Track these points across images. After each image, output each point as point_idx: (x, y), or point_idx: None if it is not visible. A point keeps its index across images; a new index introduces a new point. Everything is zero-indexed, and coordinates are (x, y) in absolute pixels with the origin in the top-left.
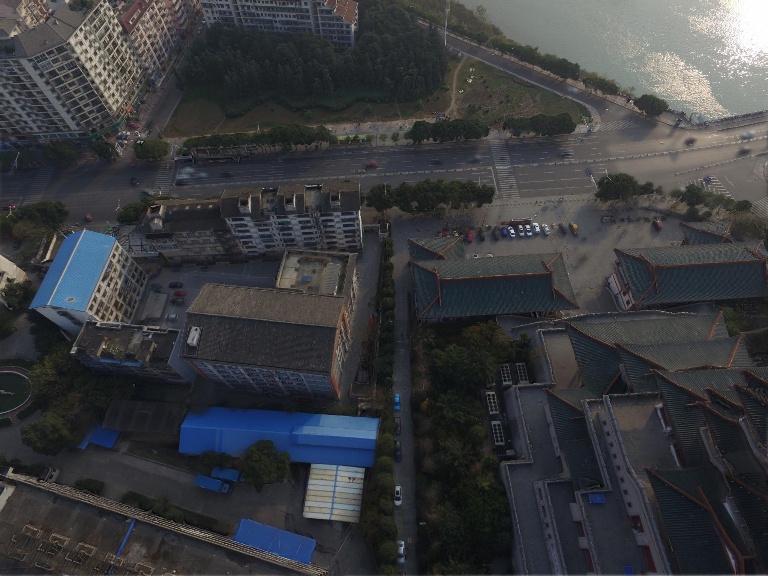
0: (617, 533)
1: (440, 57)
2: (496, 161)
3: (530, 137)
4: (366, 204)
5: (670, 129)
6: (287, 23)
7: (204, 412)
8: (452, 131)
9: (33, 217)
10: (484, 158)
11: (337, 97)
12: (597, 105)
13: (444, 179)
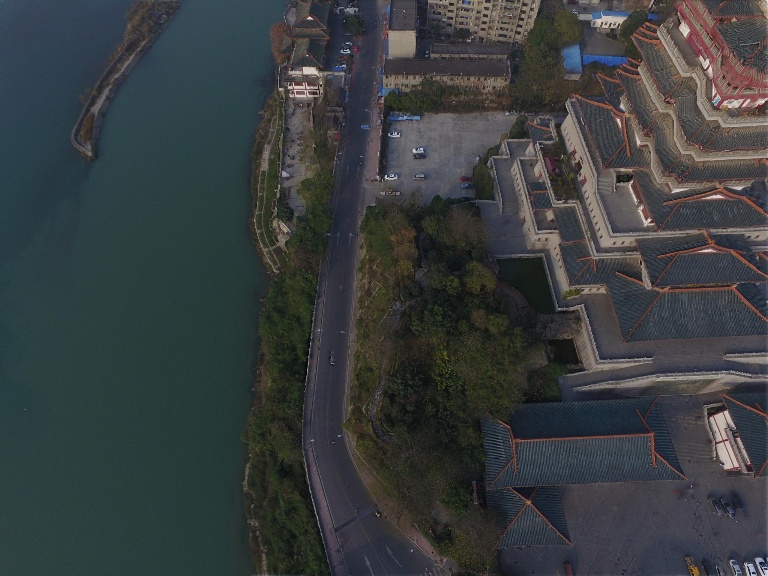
0: None
1: None
2: None
3: None
4: None
5: None
6: None
7: None
8: None
9: None
10: None
11: None
12: None
13: None
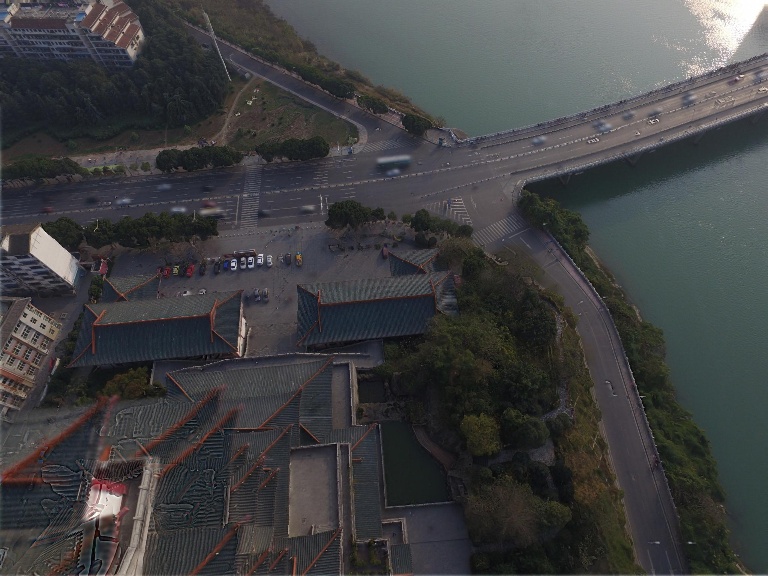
0: None
1: (208, 81)
2: (246, 188)
3: (289, 161)
4: (86, 241)
5: (433, 148)
6: (64, 50)
7: None
8: (197, 159)
9: None
10: (235, 185)
11: (106, 125)
12: (369, 125)
13: (168, 212)
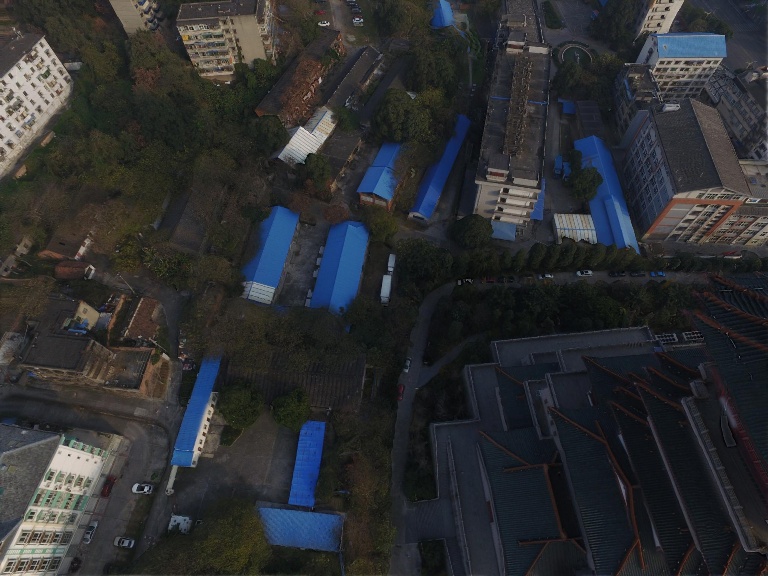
0: None
1: None
2: None
3: None
4: None
5: None
6: None
7: (606, 148)
8: None
9: (712, 24)
10: None
11: None
12: None
13: None
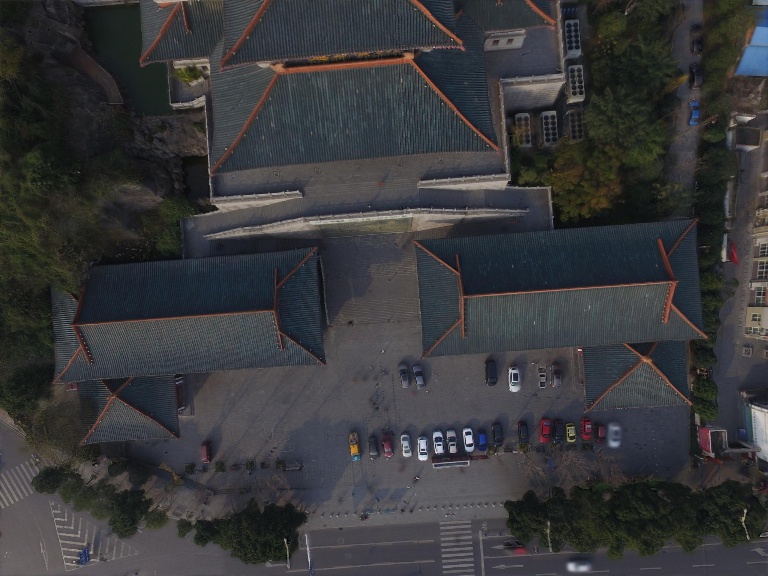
0: None
1: None
2: None
3: None
4: (759, 500)
5: None
6: None
7: None
8: None
9: None
10: None
11: None
12: None
13: None
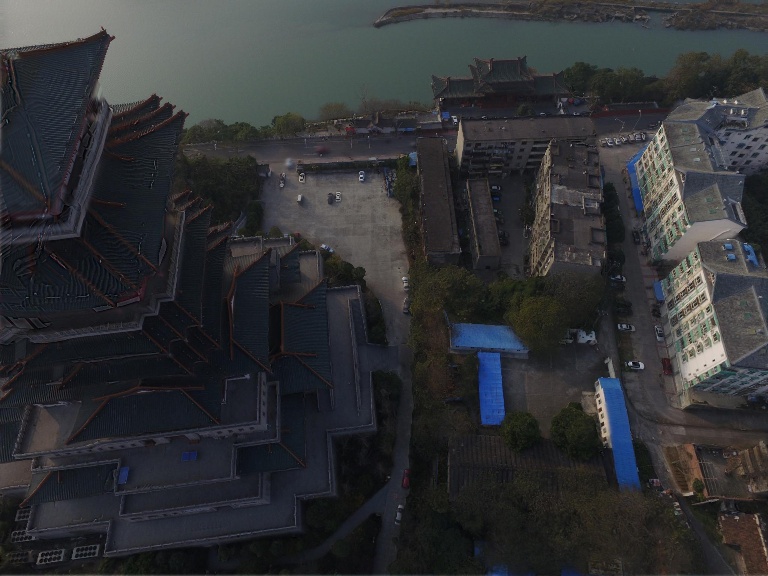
0: (157, 460)
1: None
2: None
3: None
4: None
5: None
6: None
7: None
8: None
9: None
10: None
11: None
12: None
13: None
